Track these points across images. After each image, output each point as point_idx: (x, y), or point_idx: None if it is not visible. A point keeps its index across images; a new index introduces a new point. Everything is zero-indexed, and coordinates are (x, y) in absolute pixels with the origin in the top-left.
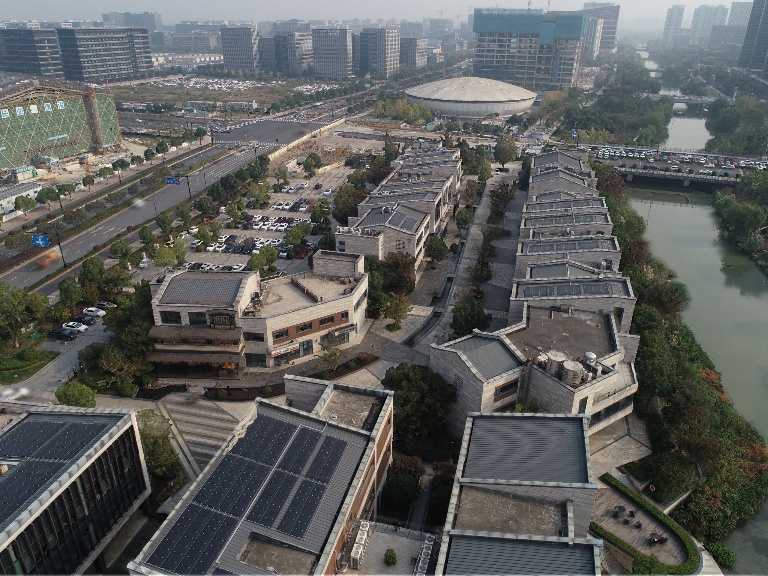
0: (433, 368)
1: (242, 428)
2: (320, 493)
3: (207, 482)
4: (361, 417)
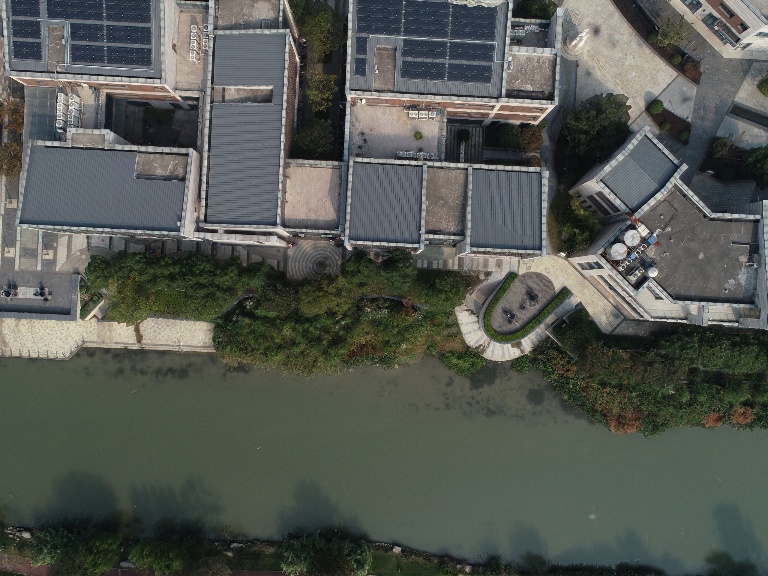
0: (632, 135)
1: (477, 2)
2: (438, 78)
3: (422, 2)
4: (525, 86)
